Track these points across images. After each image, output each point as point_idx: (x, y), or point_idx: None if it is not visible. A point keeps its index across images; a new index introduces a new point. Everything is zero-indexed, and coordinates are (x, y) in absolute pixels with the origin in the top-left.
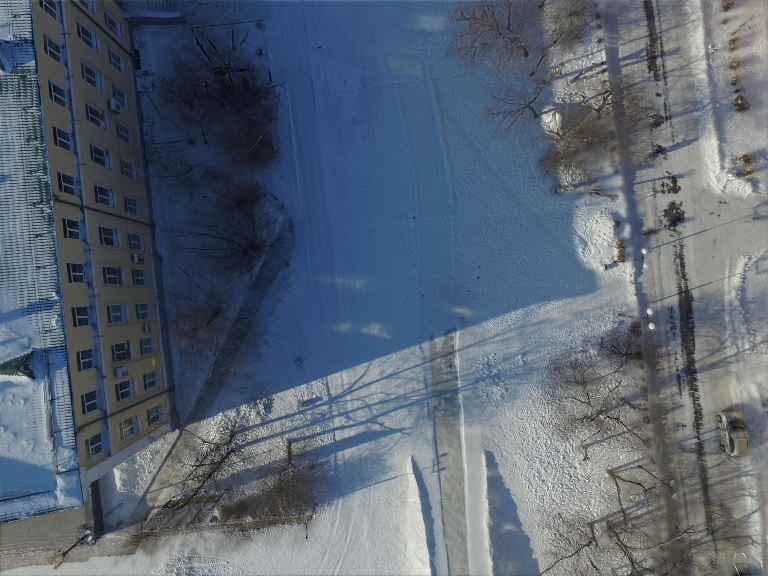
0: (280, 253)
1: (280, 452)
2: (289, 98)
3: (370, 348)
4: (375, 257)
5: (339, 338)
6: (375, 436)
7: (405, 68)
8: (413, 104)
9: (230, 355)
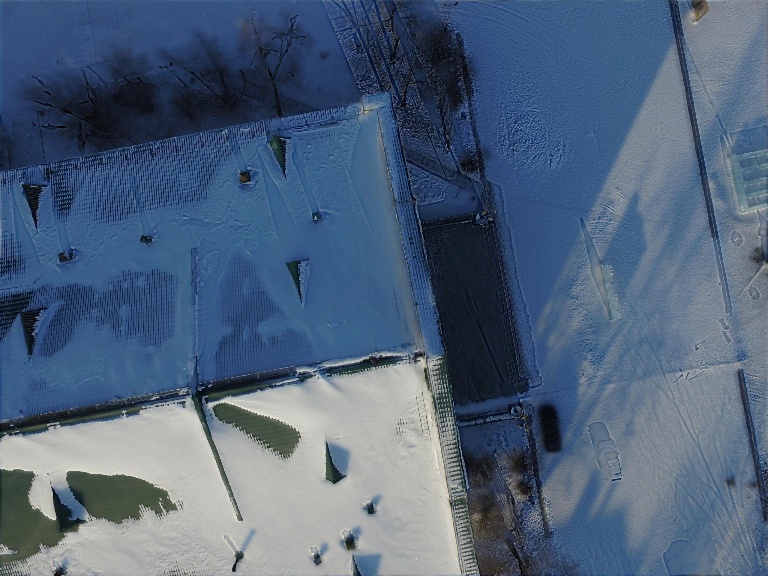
0: (233, 81)
1: (403, 66)
2: (101, 84)
3: None
4: (231, 0)
5: (302, 24)
6: None
7: None
8: None
9: None
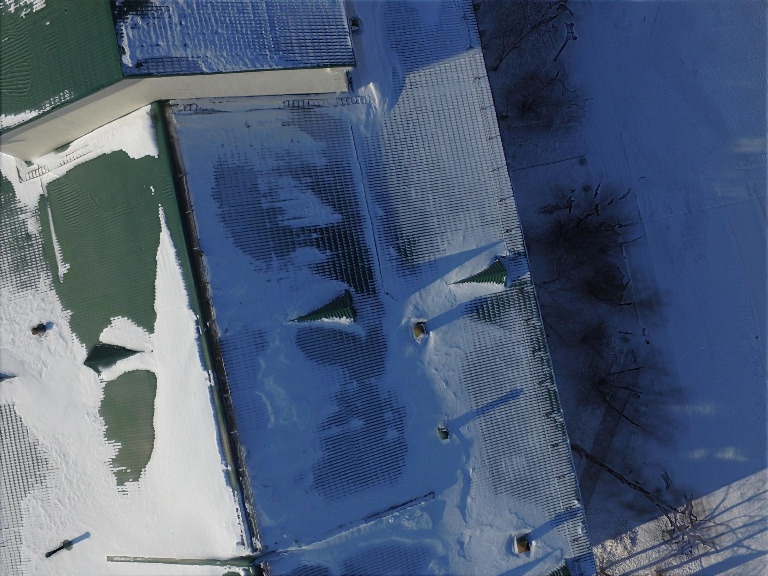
0: (626, 384)
1: None
2: (619, 230)
3: (727, 471)
4: (721, 380)
5: (695, 464)
6: (743, 559)
7: (729, 189)
8: (741, 224)
9: (587, 490)
